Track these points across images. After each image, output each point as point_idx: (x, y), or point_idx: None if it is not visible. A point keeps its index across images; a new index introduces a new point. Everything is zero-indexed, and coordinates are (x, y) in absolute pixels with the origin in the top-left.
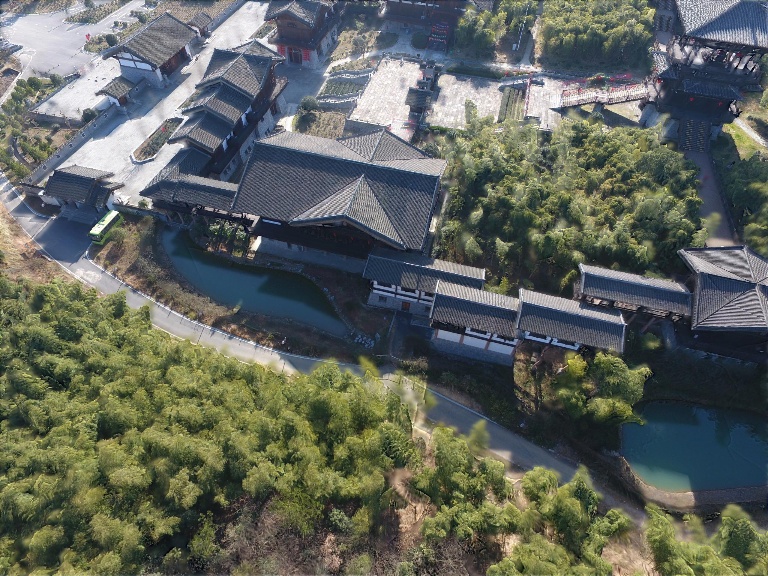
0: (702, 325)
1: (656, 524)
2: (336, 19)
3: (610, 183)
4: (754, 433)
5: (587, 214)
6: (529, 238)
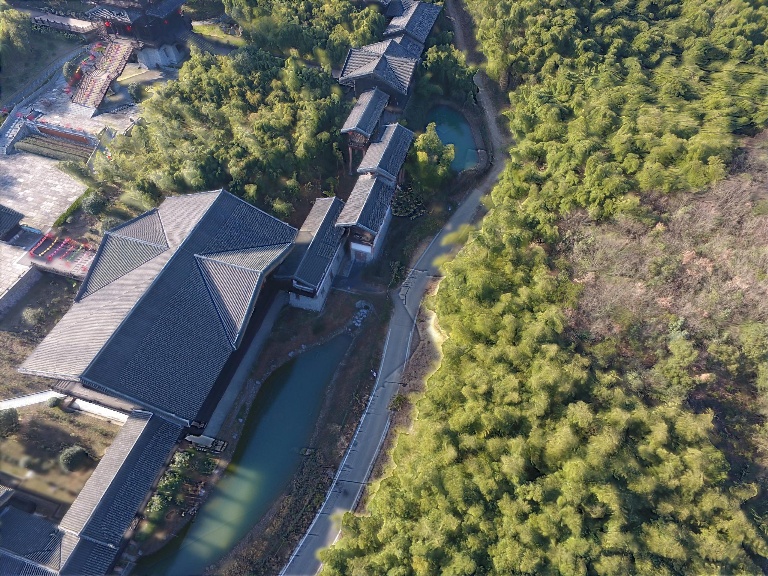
0: (406, 88)
1: (518, 151)
2: None
3: (252, 95)
4: None
5: None
6: (295, 160)
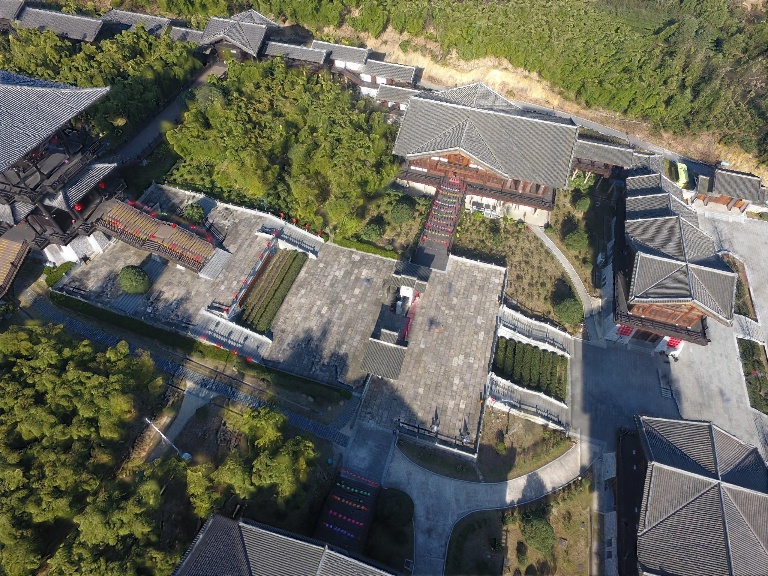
0: (278, 25)
1: None
2: None
3: None
4: None
5: None
6: None
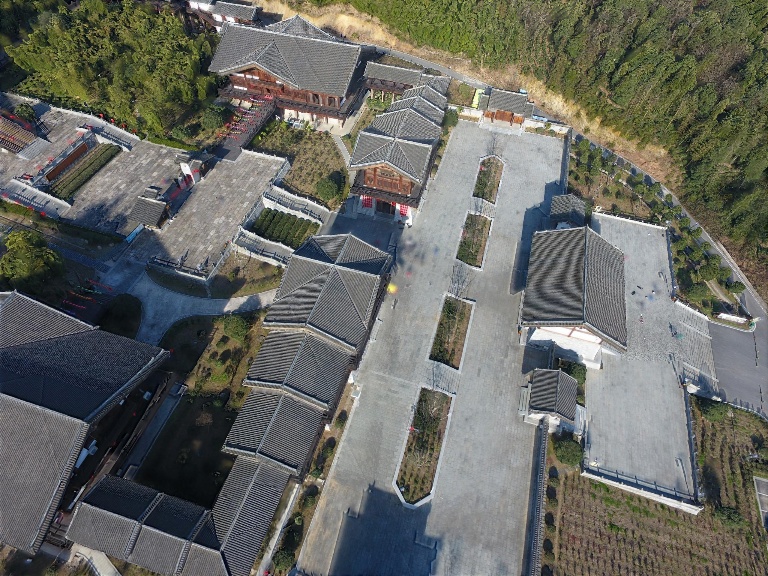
0: None
1: None
2: None
3: None
4: None
5: None
6: None
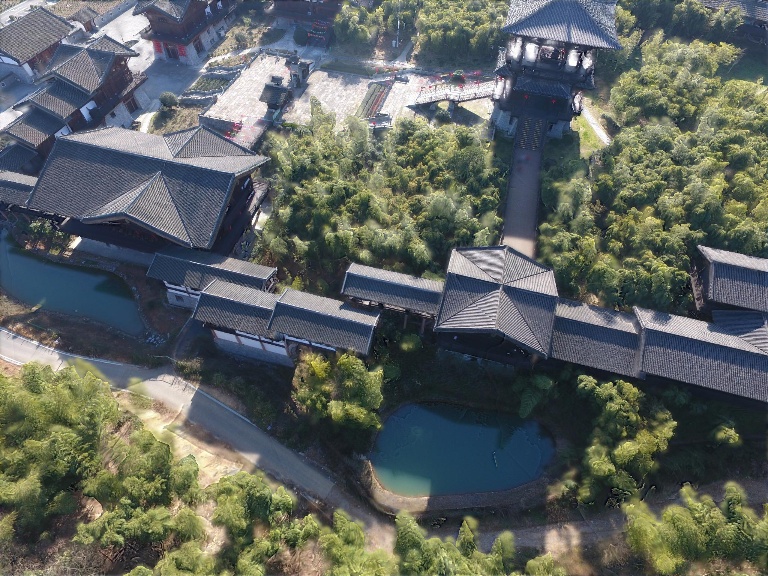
0: (441, 326)
1: (338, 531)
2: (222, 14)
3: (417, 181)
4: (527, 436)
5: (389, 213)
6: (324, 237)
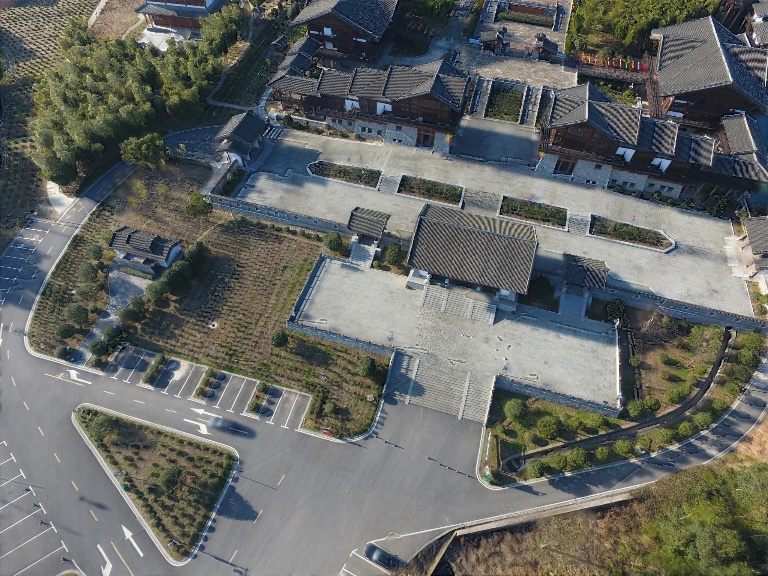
0: None
1: None
2: None
3: None
4: None
5: None
6: None
